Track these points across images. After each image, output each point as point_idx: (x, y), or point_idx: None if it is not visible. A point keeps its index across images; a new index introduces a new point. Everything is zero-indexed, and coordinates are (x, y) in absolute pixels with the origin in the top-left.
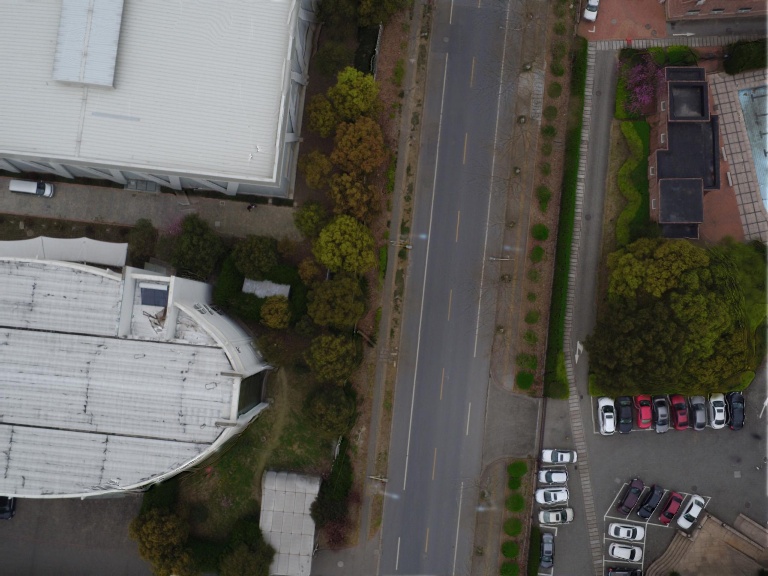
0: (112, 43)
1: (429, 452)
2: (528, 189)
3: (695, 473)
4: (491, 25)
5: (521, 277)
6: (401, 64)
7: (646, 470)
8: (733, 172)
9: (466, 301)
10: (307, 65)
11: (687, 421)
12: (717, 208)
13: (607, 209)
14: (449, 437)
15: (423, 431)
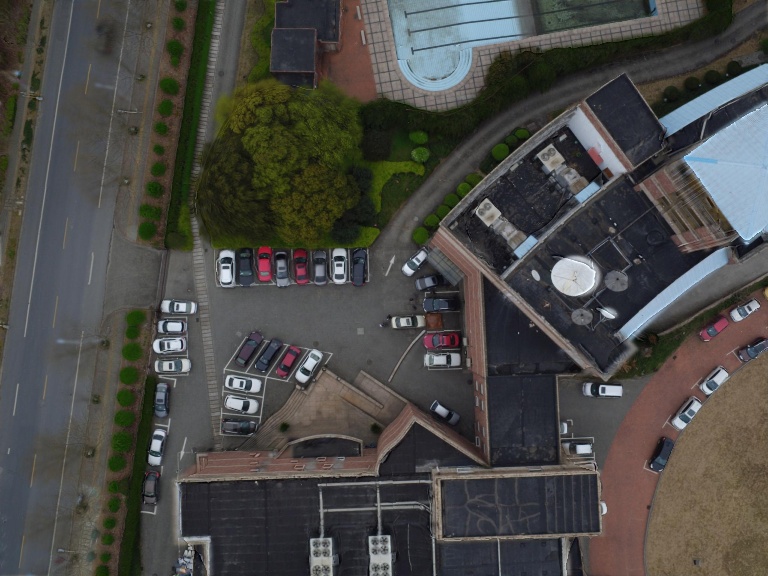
0: None
1: (51, 300)
2: (159, 44)
3: (317, 329)
4: None
5: (148, 130)
6: None
7: (268, 324)
8: (369, 31)
9: (93, 152)
10: None
11: (306, 275)
12: (351, 66)
13: (241, 66)
14: (71, 286)
15: (46, 280)
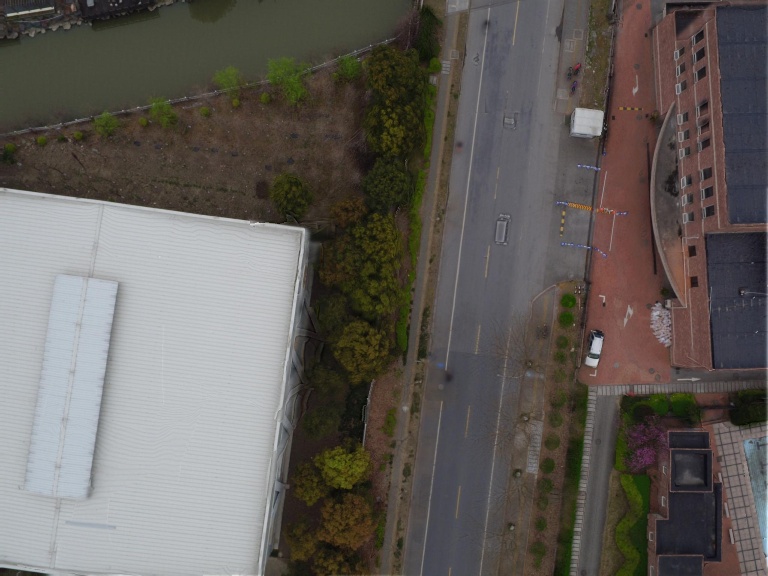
0: (92, 418)
1: None
2: (522, 546)
3: None
4: (488, 372)
5: None
6: (394, 413)
7: None
8: (735, 528)
9: None
10: (295, 425)
11: None
12: (718, 565)
13: (604, 564)
14: None
15: None
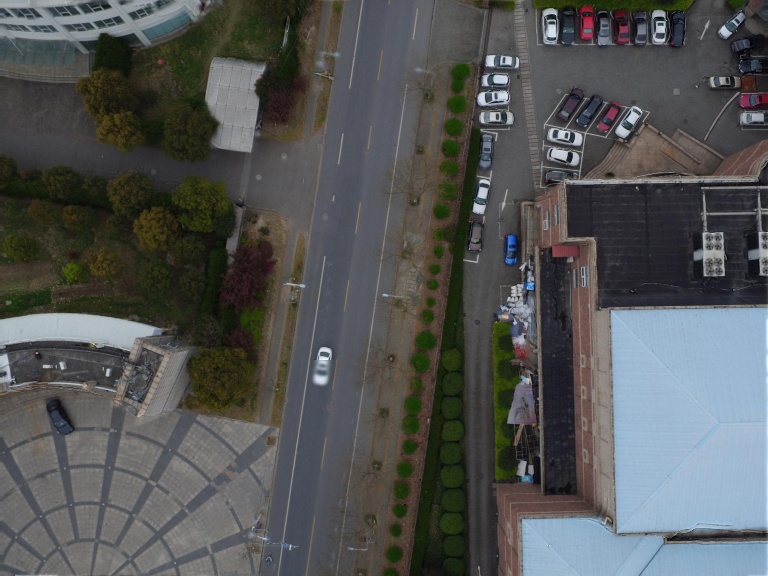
0: None
1: (375, 54)
2: None
3: (635, 88)
4: None
5: None
6: None
7: (587, 83)
8: None
9: None
10: None
11: (628, 33)
12: None
13: None
14: (396, 40)
15: (371, 34)
